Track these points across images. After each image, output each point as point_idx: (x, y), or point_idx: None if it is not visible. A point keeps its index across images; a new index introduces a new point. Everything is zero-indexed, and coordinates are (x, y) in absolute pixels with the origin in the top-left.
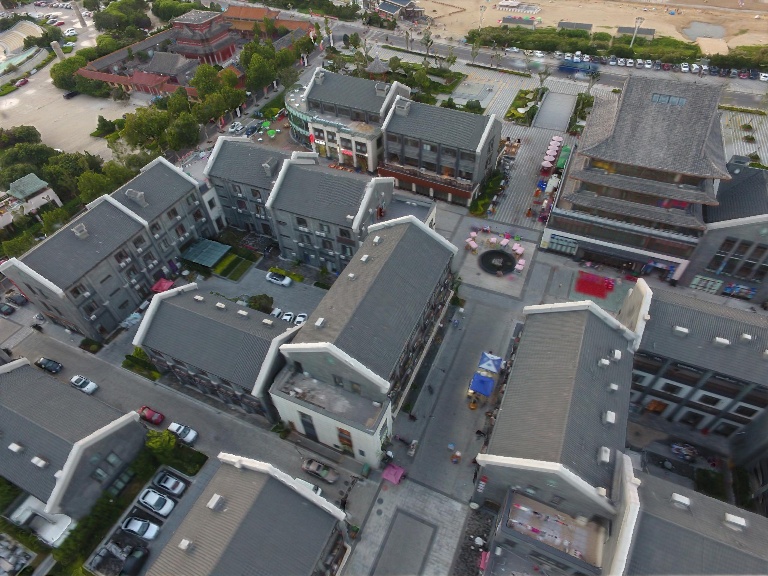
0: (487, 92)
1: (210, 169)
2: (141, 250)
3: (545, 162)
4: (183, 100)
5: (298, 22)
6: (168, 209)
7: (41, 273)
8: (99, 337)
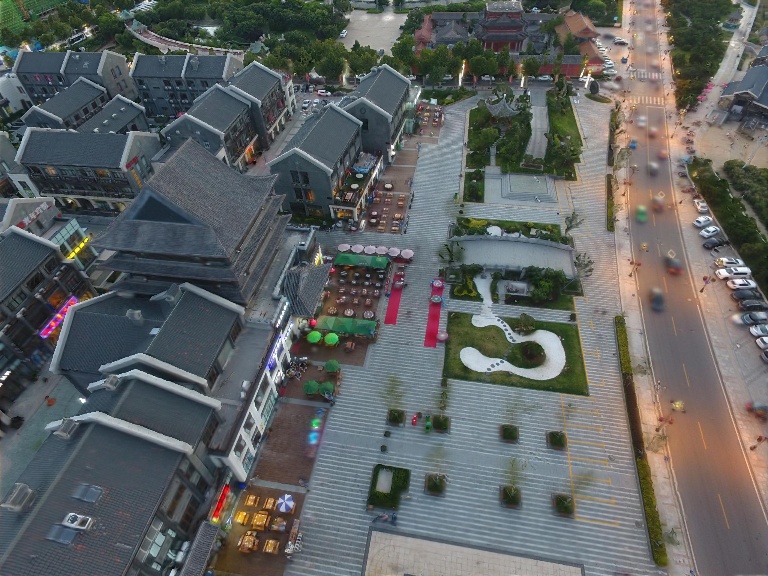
0: (530, 199)
1: (238, 75)
2: (179, 88)
3: (345, 244)
4: (370, 51)
5: (593, 51)
6: (201, 79)
7: (138, 65)
8: (148, 112)
